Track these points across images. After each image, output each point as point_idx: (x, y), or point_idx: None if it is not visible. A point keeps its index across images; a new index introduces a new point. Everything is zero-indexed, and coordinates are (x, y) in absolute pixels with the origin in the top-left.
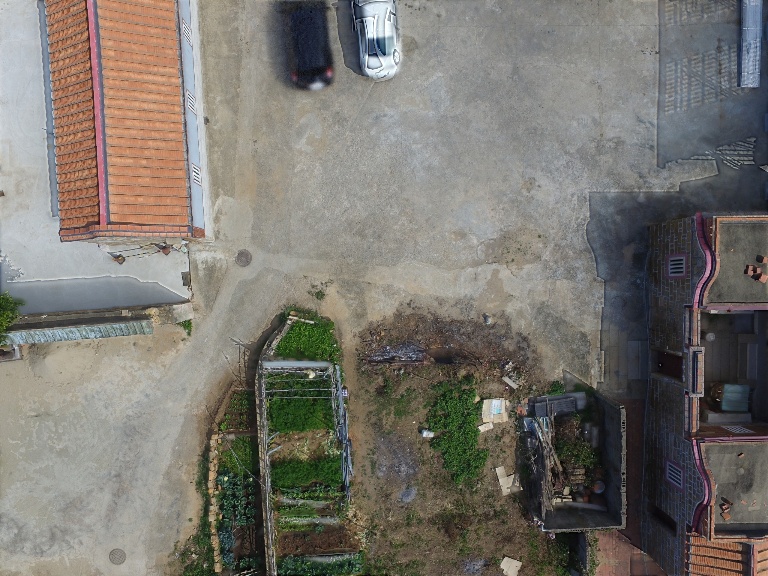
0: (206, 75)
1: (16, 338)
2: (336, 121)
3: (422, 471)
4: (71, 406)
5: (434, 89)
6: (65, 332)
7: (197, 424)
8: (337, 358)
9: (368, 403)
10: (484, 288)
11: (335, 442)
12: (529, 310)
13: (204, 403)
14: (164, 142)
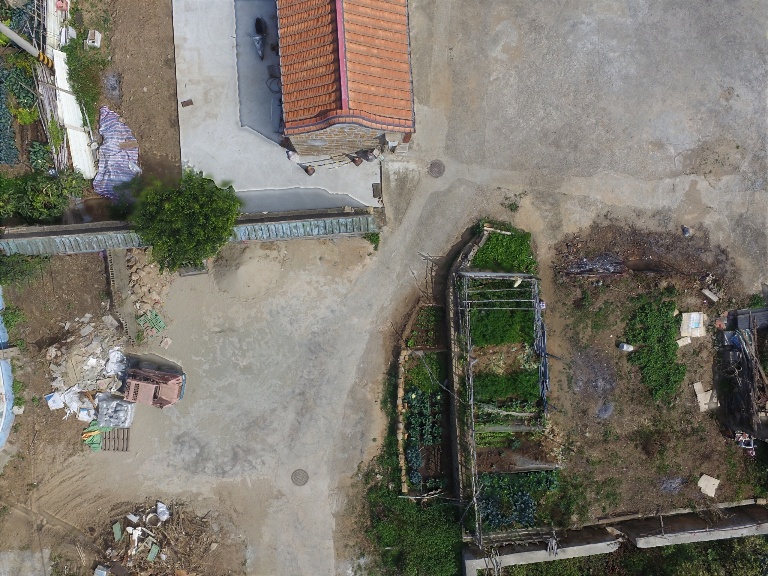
0: None
1: (239, 234)
2: (533, 28)
3: (619, 386)
4: (256, 322)
5: None
6: (290, 227)
7: (382, 341)
8: (533, 270)
9: (565, 316)
10: (682, 199)
11: (532, 356)
12: (727, 222)
13: (389, 320)
14: (392, 33)
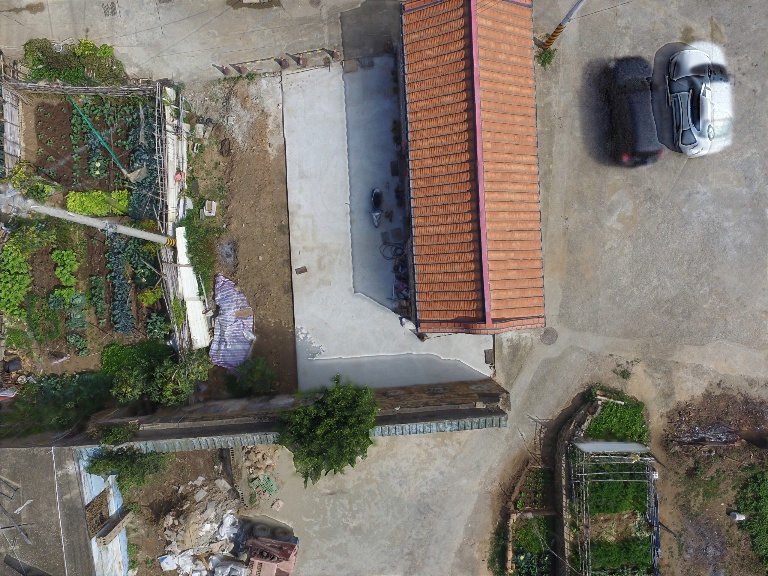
0: None
1: (373, 432)
2: (648, 198)
3: (729, 553)
4: (366, 484)
5: (748, 166)
6: (423, 426)
7: (490, 502)
8: (645, 439)
9: (676, 485)
10: None
11: (644, 524)
12: None
13: (497, 480)
14: (526, 232)
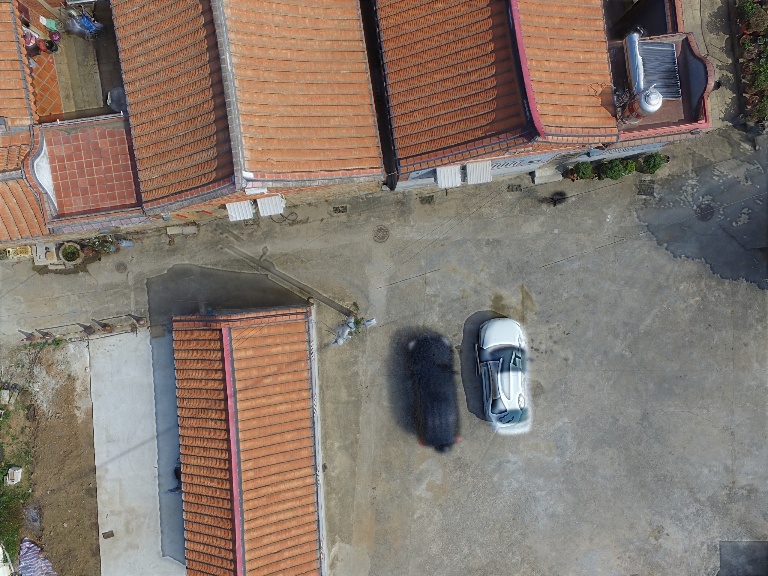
0: (325, 421)
1: None
2: (458, 467)
3: None
4: None
5: (560, 435)
6: None
7: None
8: None
9: None
10: None
11: None
12: None
13: None
14: (299, 548)
